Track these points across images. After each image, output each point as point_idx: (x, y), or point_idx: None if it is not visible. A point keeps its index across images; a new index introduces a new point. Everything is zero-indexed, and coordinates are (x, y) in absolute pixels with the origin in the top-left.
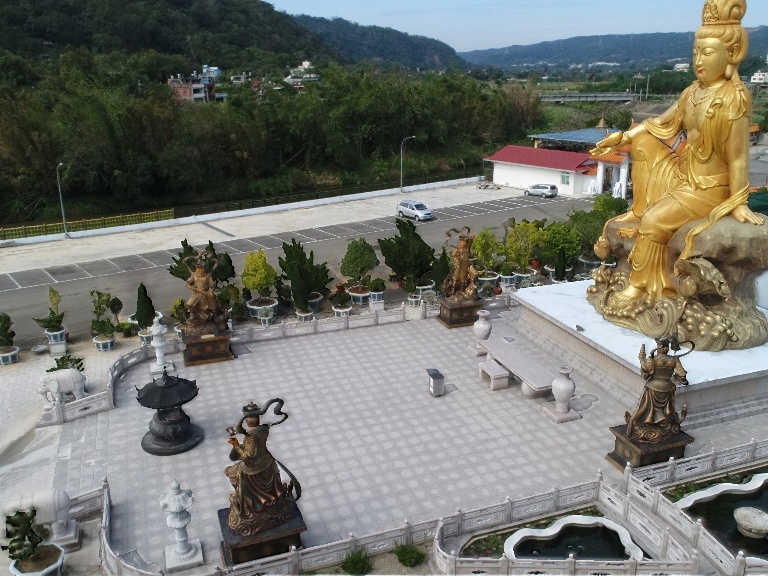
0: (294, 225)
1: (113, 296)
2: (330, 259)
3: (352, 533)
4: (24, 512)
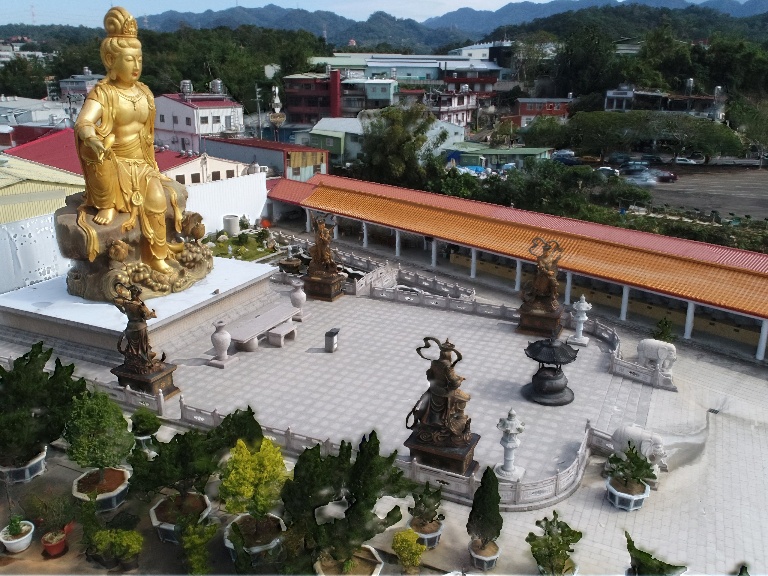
0: None
1: None
2: None
3: (504, 303)
4: (663, 320)
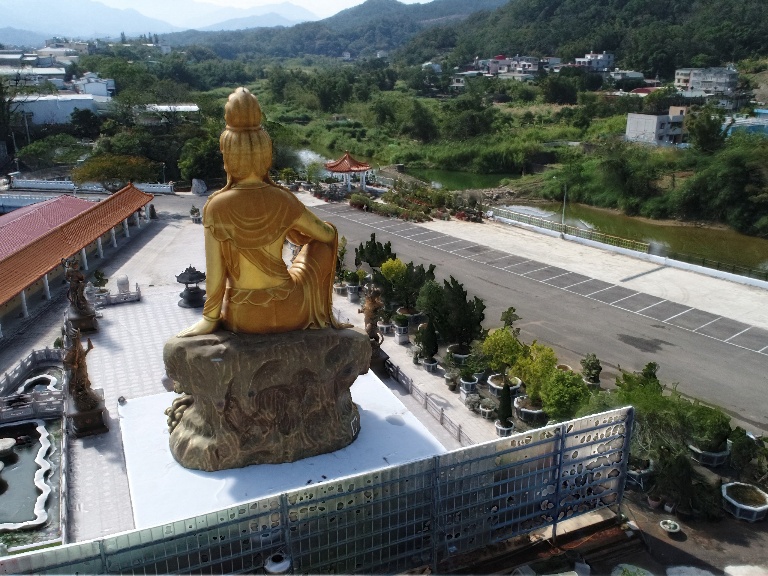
0: (698, 299)
1: (425, 268)
2: (565, 321)
3: None
4: None
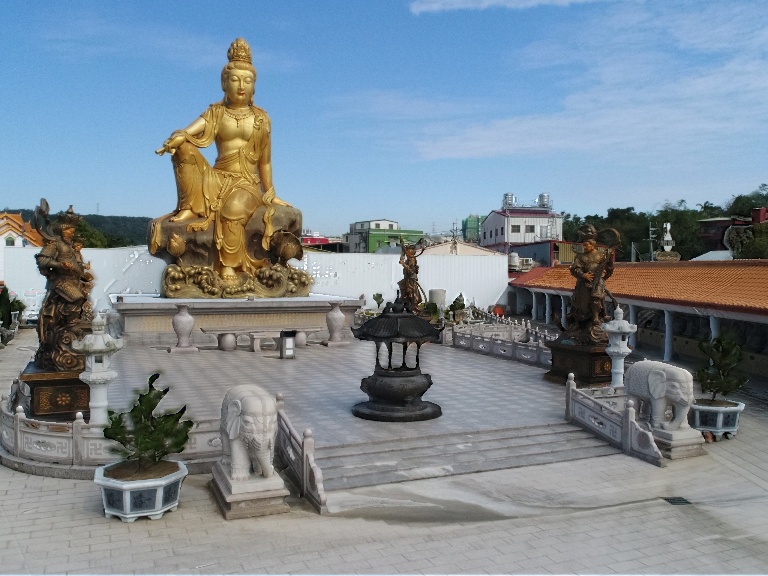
0: None
1: None
2: None
3: None
4: None
